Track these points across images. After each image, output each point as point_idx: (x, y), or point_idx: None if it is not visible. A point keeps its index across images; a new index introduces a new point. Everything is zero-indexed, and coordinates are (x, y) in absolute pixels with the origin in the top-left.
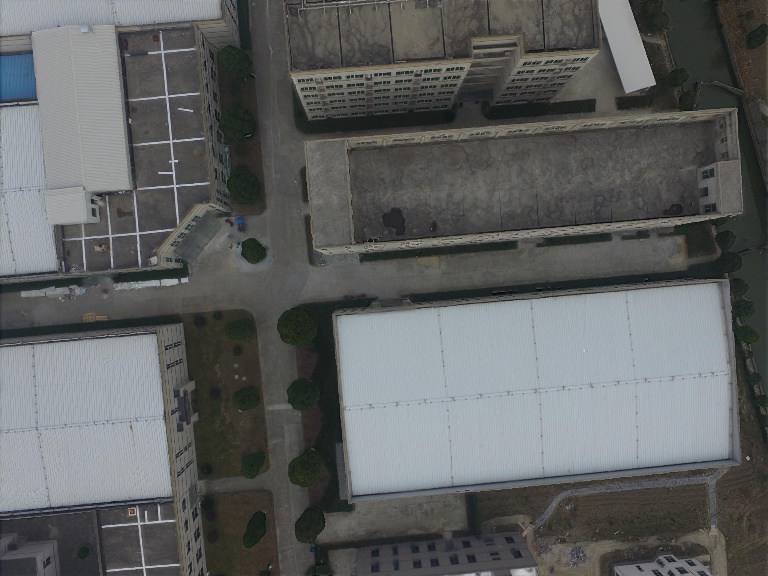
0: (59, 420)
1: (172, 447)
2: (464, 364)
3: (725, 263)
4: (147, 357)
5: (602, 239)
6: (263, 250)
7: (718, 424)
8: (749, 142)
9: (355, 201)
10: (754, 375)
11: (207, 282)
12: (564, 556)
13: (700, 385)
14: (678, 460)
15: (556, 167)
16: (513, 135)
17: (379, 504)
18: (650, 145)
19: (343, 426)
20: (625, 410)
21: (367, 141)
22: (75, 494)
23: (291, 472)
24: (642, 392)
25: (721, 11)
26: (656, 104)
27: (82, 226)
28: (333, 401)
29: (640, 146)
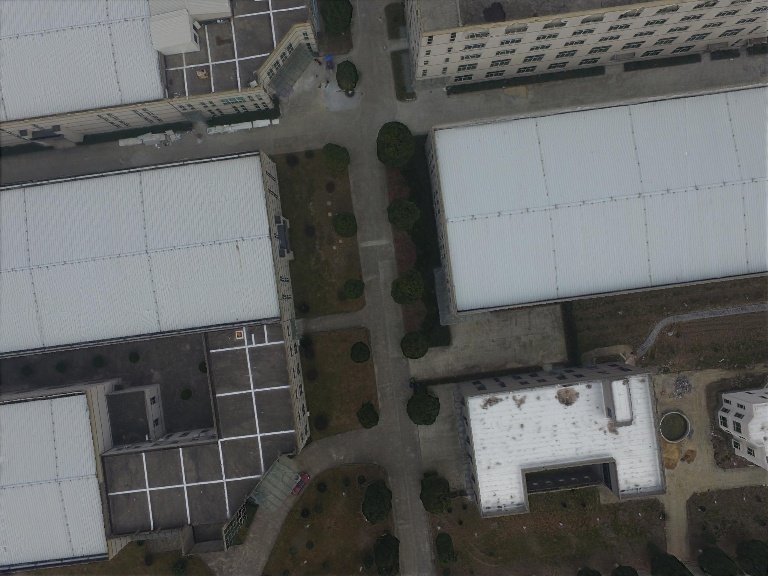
0: (168, 243)
1: (277, 266)
2: (565, 172)
3: None
4: (250, 178)
5: (691, 60)
6: (357, 74)
7: None
8: None
9: None
10: None
11: (297, 123)
12: (668, 387)
13: None
14: None
15: None
16: None
17: (476, 338)
18: None
19: (447, 237)
20: (732, 212)
21: None
22: (187, 311)
23: (395, 289)
24: (749, 193)
25: None
26: None
27: (183, 56)
28: (427, 234)
29: None
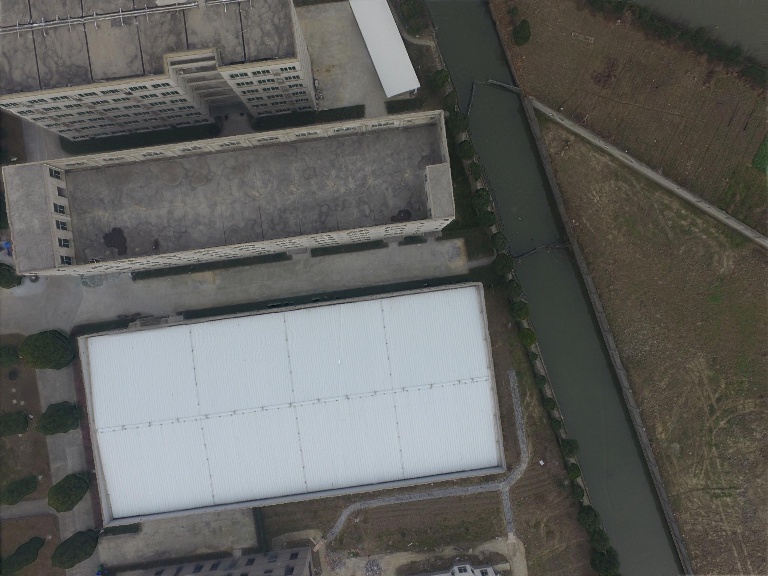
0: None
1: None
2: (217, 381)
3: (496, 265)
4: None
5: (377, 246)
6: None
7: (483, 431)
8: (532, 140)
9: (75, 223)
10: (538, 378)
11: None
12: (359, 570)
13: (460, 392)
14: (445, 469)
15: (278, 178)
16: (232, 148)
17: (166, 524)
18: (373, 151)
19: (94, 449)
20: (385, 421)
21: (75, 162)
22: None
23: None
24: (401, 401)
25: (492, 8)
26: (426, 106)
27: None
28: None
29: (363, 153)
